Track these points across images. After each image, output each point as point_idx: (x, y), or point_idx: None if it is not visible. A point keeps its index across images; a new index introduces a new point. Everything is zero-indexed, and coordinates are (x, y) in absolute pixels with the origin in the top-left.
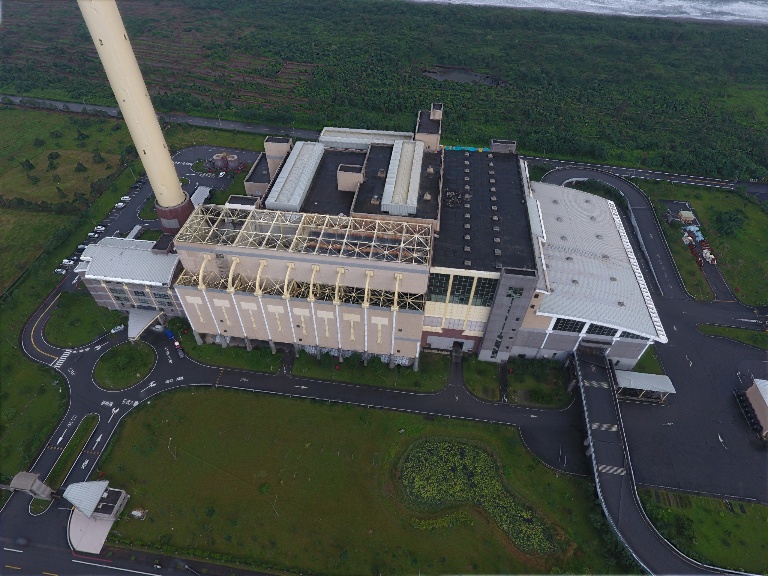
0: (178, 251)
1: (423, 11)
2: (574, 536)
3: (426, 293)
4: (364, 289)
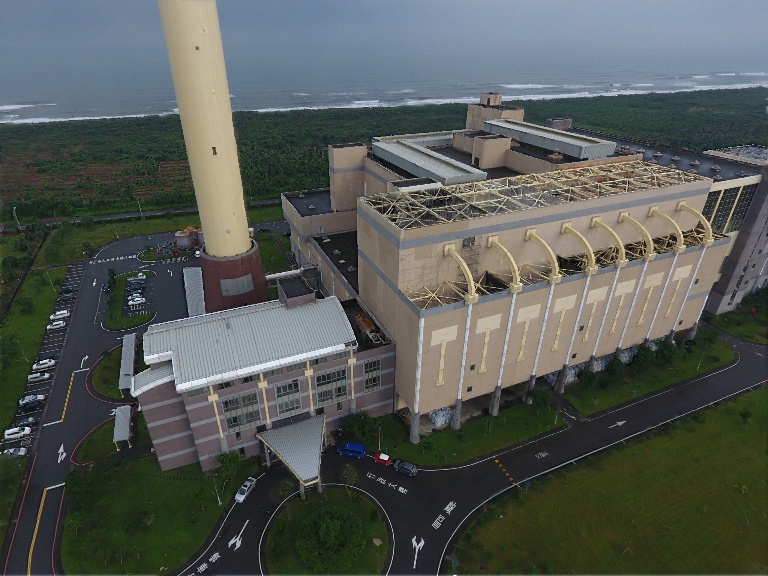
0: (401, 253)
1: (269, 116)
2: None
3: None
4: (641, 241)
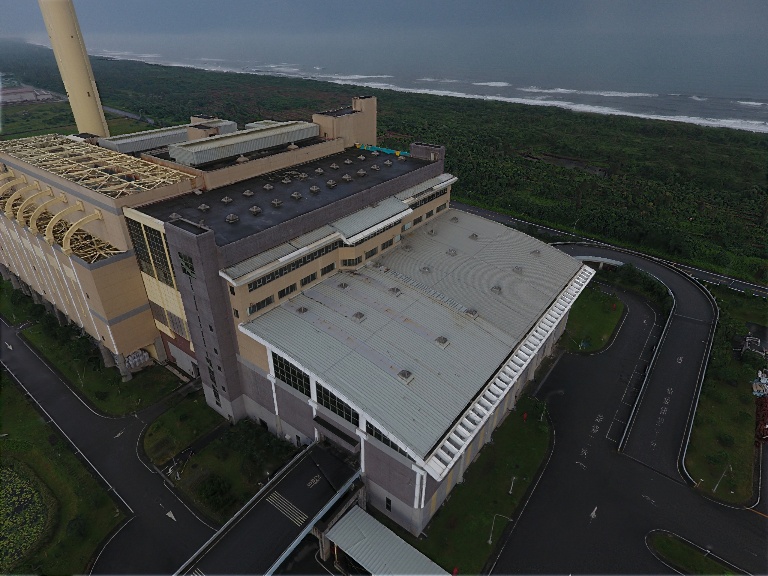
0: None
1: (573, 115)
2: None
3: (136, 255)
4: (84, 232)
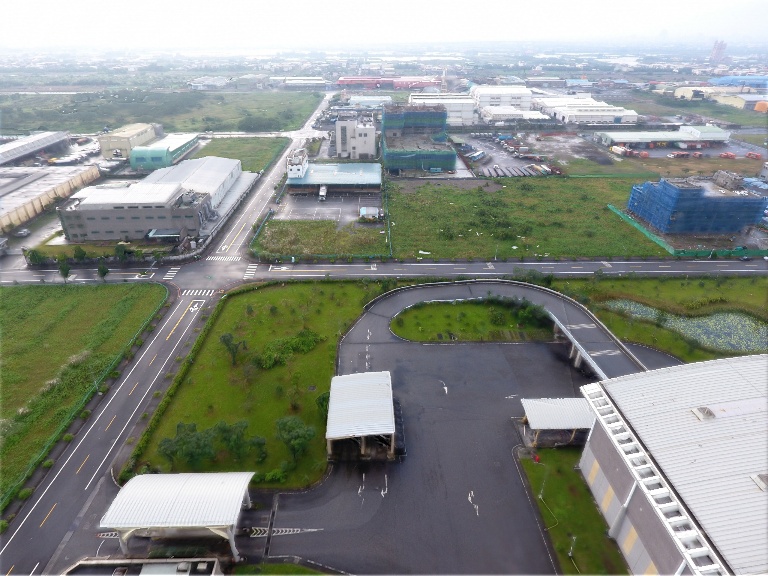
0: None
1: None
2: (591, 306)
3: None
4: None
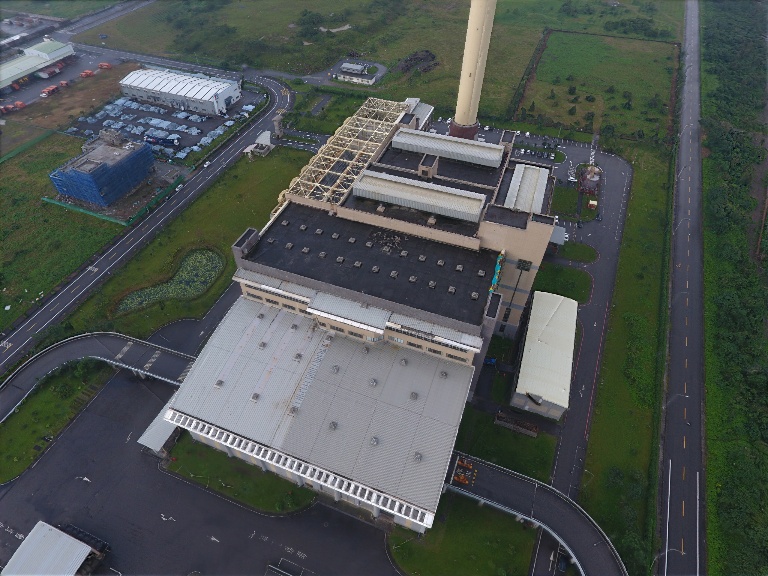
0: None
1: None
2: None
3: None
4: None
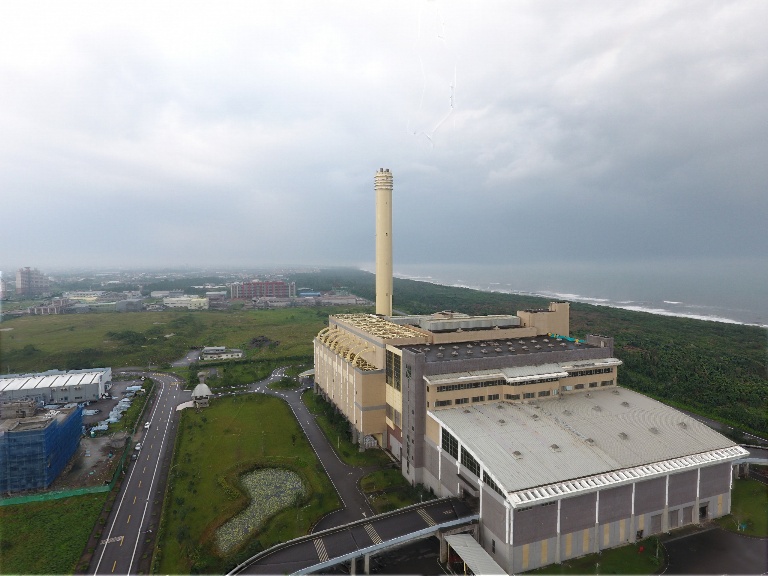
0: None
1: None
2: None
3: (386, 373)
4: (364, 360)
